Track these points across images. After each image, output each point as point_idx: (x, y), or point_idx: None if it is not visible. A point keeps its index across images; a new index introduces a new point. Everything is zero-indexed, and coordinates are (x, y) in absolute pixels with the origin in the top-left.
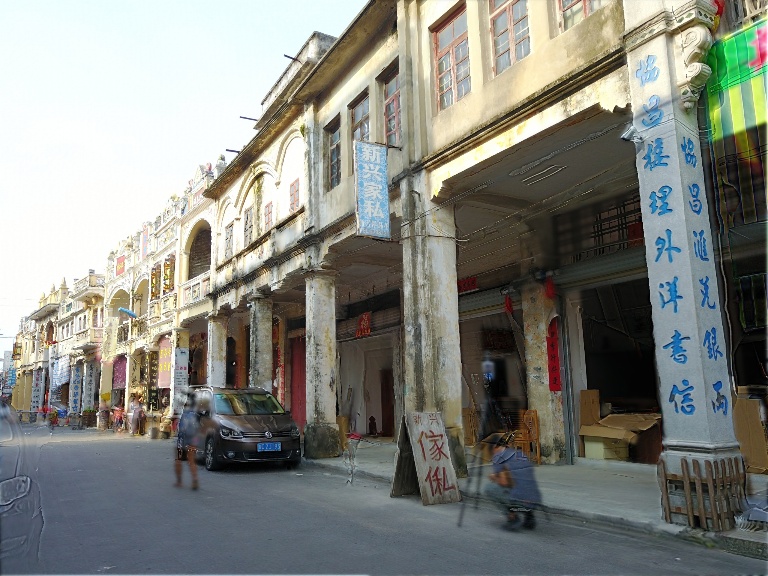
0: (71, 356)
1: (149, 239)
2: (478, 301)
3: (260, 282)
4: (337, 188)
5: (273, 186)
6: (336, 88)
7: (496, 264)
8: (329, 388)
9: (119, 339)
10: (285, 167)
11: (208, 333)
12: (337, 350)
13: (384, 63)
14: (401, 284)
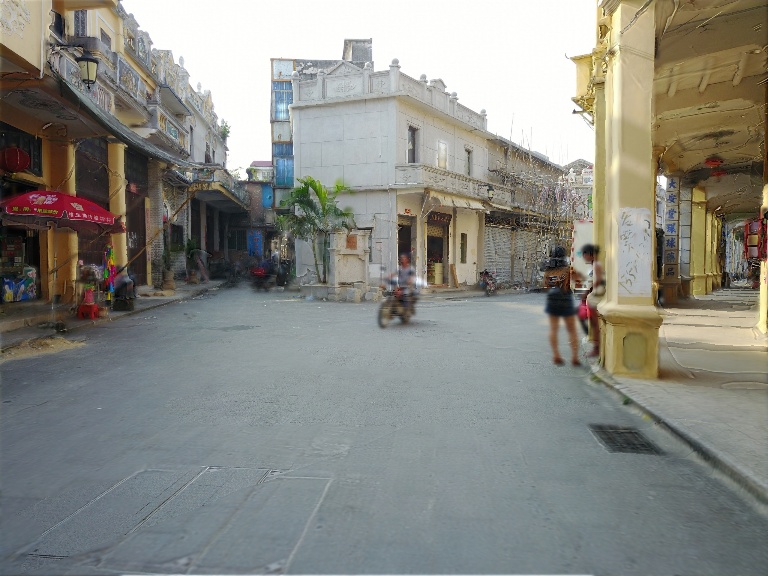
0: None
1: None
2: None
3: None
4: None
5: None
6: None
7: None
8: (740, 265)
9: None
10: None
11: None
12: None
13: None
14: None
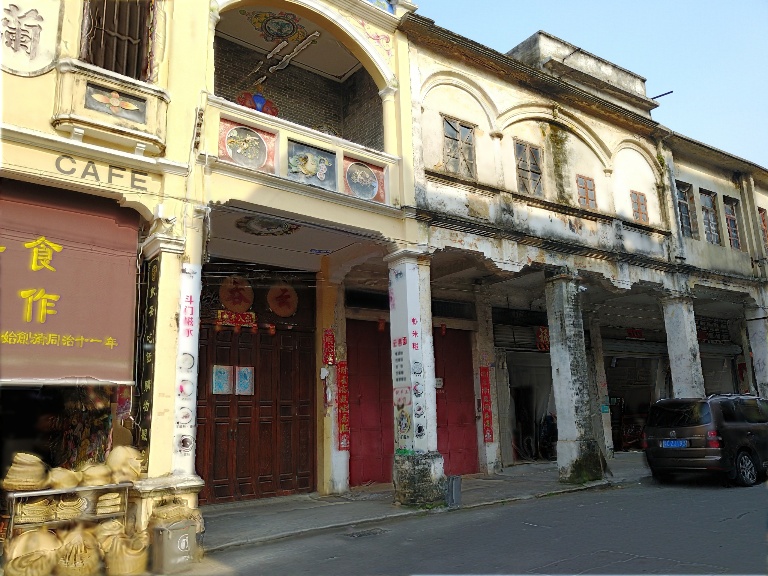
0: None
1: None
2: (645, 347)
3: (586, 264)
4: (698, 242)
5: (596, 165)
6: (686, 162)
7: (652, 327)
8: None
9: None
10: (622, 165)
11: (412, 283)
12: (503, 359)
13: (729, 193)
14: (591, 314)
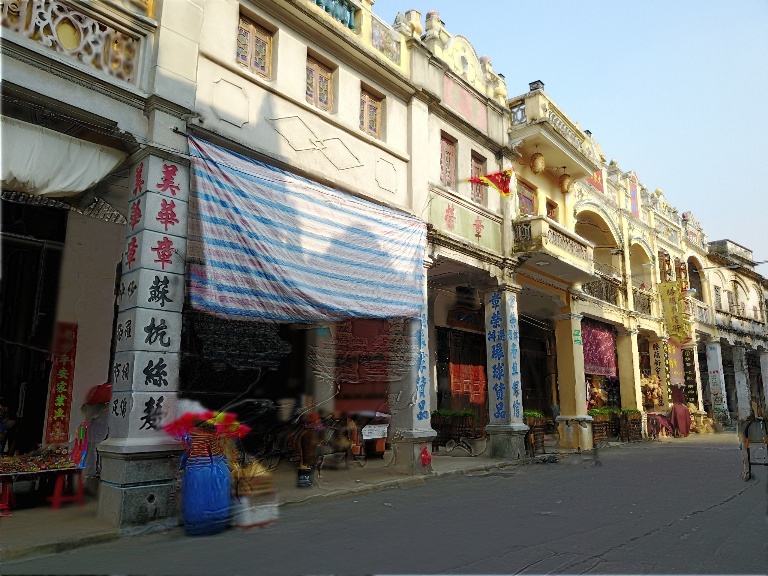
0: (433, 232)
1: (648, 208)
2: (733, 370)
3: (746, 340)
4: None
5: None
6: (765, 289)
7: None
8: None
9: (598, 292)
10: None
11: None
12: None
13: None
14: None
